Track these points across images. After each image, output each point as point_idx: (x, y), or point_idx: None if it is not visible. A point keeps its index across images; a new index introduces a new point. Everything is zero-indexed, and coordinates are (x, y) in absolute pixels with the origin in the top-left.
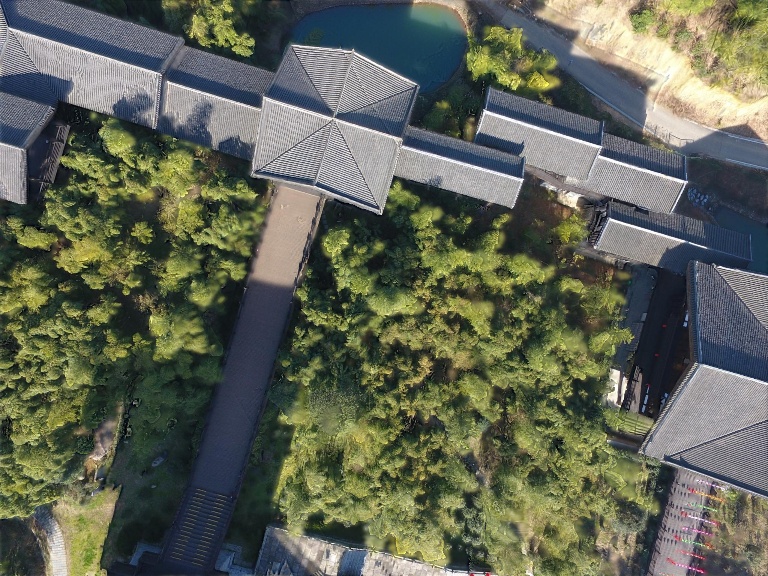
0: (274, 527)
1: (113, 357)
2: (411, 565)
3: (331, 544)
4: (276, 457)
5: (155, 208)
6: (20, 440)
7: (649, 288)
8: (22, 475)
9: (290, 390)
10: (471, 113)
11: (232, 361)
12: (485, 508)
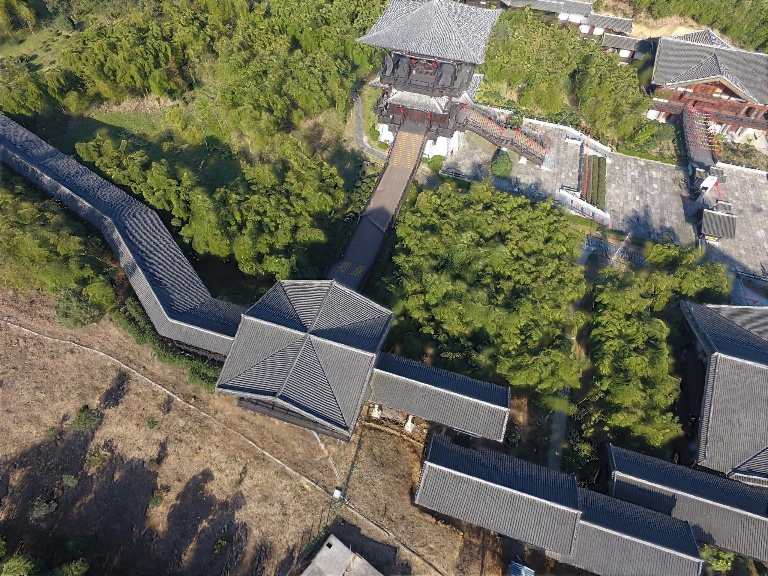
0: None
1: None
2: None
3: (501, 107)
4: None
5: None
6: None
7: None
8: None
9: None
10: None
11: None
12: None
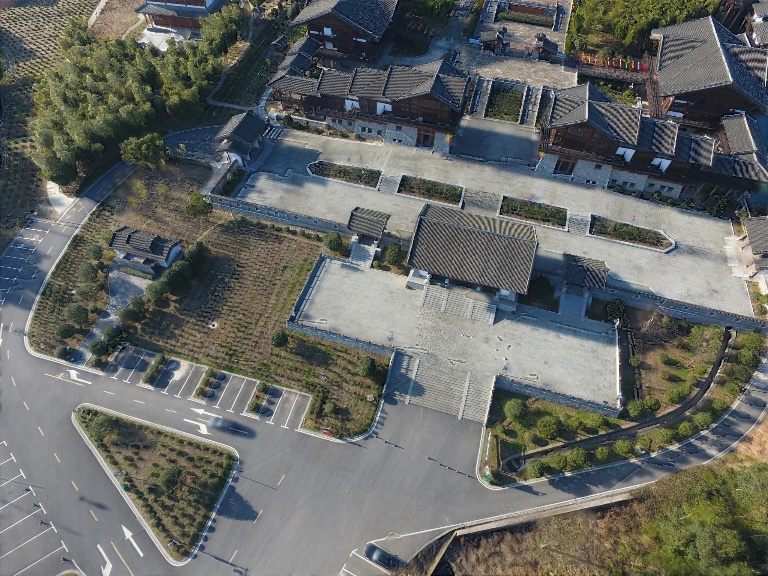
0: None
1: None
2: (569, 0)
3: None
4: None
5: None
6: None
7: None
8: None
9: None
10: None
11: None
12: None
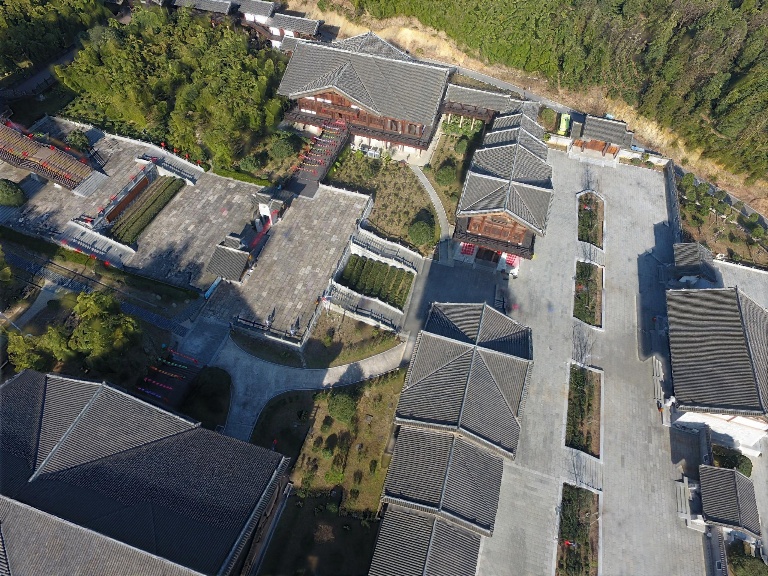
0: None
1: (7, 16)
2: (128, 145)
3: (80, 122)
4: (70, 95)
5: None
6: None
7: None
8: None
9: (85, 32)
10: None
11: None
12: None
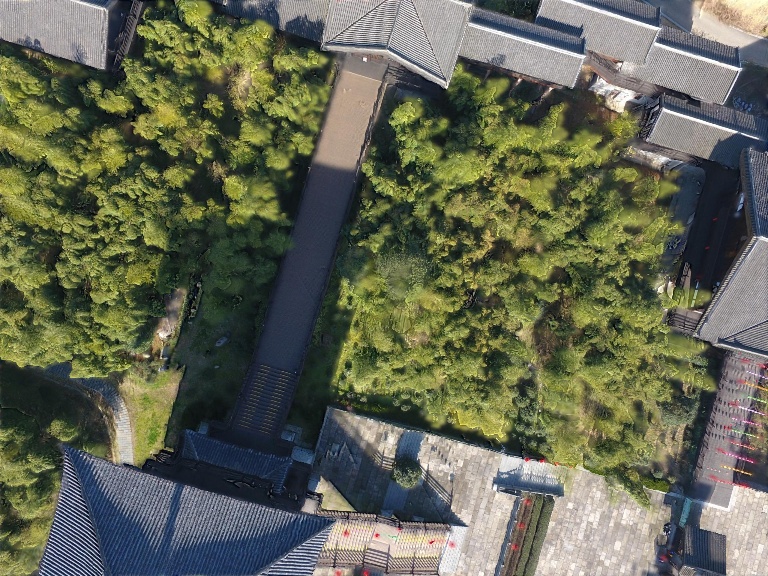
0: (334, 408)
1: (190, 217)
2: (466, 450)
3: (390, 424)
4: (336, 340)
5: (224, 85)
6: (99, 297)
7: (694, 194)
8: (99, 334)
9: (360, 254)
10: (527, 5)
11: (295, 241)
12: (541, 390)
